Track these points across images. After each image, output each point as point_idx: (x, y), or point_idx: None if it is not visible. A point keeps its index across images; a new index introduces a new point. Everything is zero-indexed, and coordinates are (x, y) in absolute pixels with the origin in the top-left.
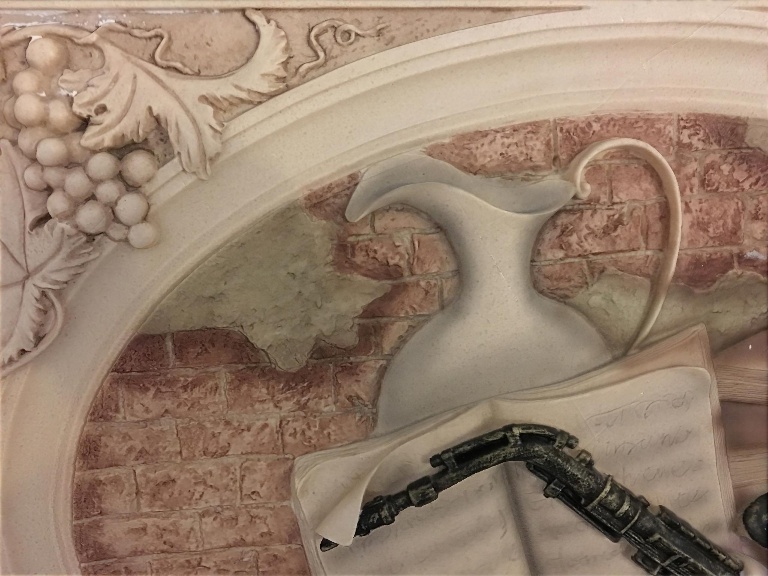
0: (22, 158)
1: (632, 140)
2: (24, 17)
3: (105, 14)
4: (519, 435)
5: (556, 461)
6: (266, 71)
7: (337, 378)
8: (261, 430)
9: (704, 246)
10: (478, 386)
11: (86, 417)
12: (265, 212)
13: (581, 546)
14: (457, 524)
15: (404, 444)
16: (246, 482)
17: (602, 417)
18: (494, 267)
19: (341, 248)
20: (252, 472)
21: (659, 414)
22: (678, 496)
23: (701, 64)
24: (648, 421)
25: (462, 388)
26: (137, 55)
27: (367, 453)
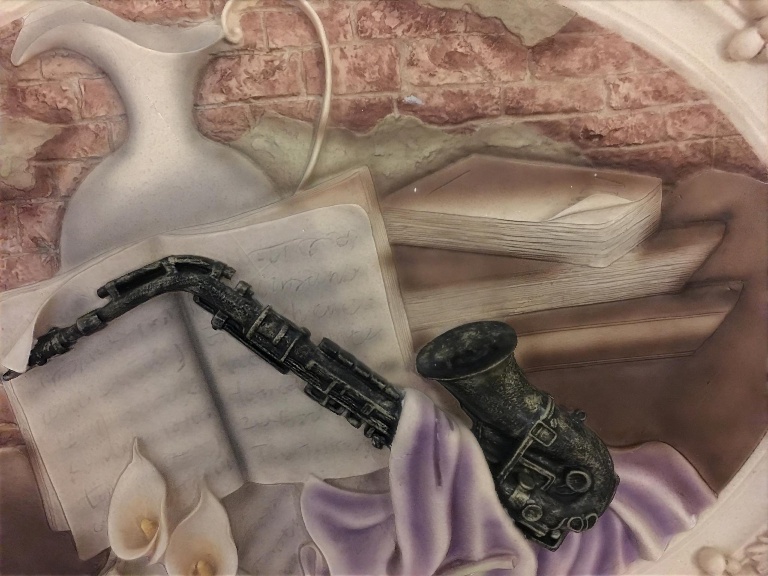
0: None
1: None
2: None
3: None
4: (174, 264)
5: (211, 289)
6: None
7: (19, 219)
8: None
9: (362, 91)
10: (146, 223)
11: None
12: None
13: (257, 380)
14: (134, 356)
15: (75, 277)
16: None
17: (264, 252)
18: (152, 107)
19: (12, 92)
20: None
21: (324, 252)
22: (351, 334)
23: None
24: (314, 259)
25: (131, 225)
26: None
27: (46, 288)
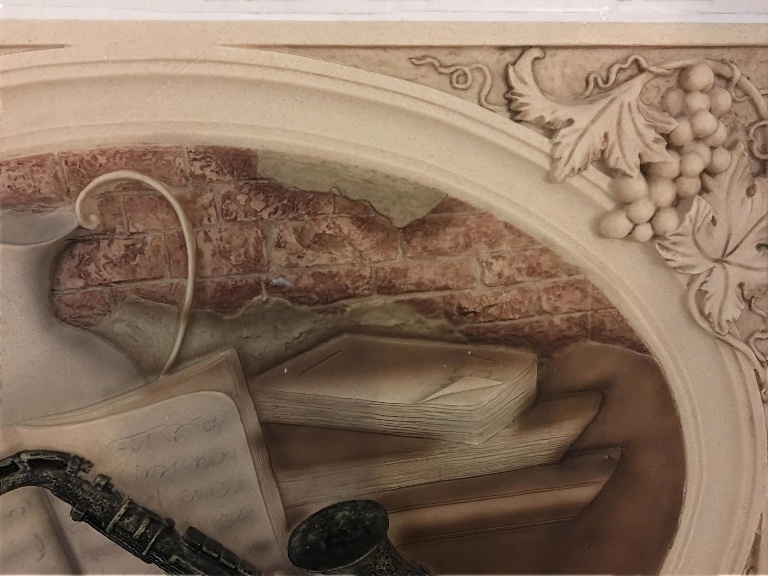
0: None
1: (128, 173)
2: None
3: None
4: (27, 461)
5: (66, 486)
6: None
7: None
8: None
9: (229, 274)
10: (0, 413)
11: None
12: None
13: (122, 567)
14: None
15: None
16: None
17: (125, 442)
18: (4, 297)
19: None
20: None
21: (190, 437)
22: (221, 517)
23: (206, 98)
24: (179, 444)
25: None
26: None
27: None
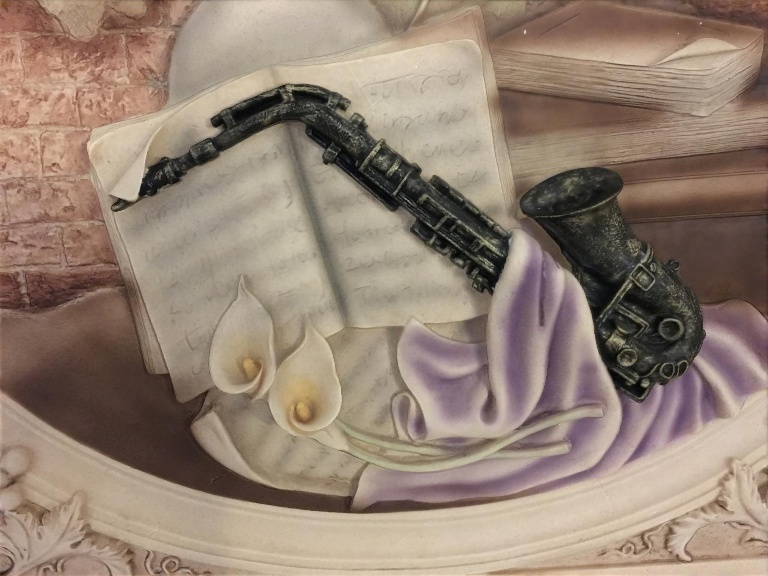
0: None
1: None
2: None
3: None
4: (292, 92)
5: (327, 118)
6: None
7: (128, 48)
8: (58, 100)
9: None
10: (259, 54)
11: None
12: None
13: (364, 219)
14: (243, 191)
15: (187, 105)
16: (46, 153)
17: (377, 86)
18: None
19: None
20: (51, 143)
21: (435, 90)
22: (457, 176)
23: None
24: (425, 97)
25: (244, 55)
26: None
27: (156, 119)
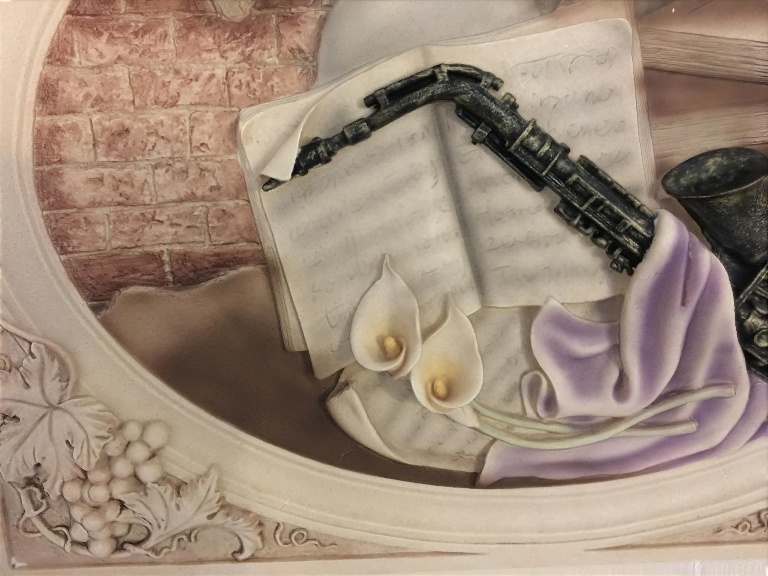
0: None
1: None
2: None
3: None
4: (447, 72)
5: (481, 98)
6: None
7: (279, 28)
8: (208, 81)
9: None
10: (411, 33)
11: (44, 62)
12: None
13: (507, 199)
14: (391, 171)
15: (340, 85)
16: (195, 133)
17: (528, 66)
18: None
19: None
20: (200, 123)
21: (583, 70)
22: (600, 156)
23: None
24: (573, 76)
25: (396, 35)
26: None
27: (307, 99)
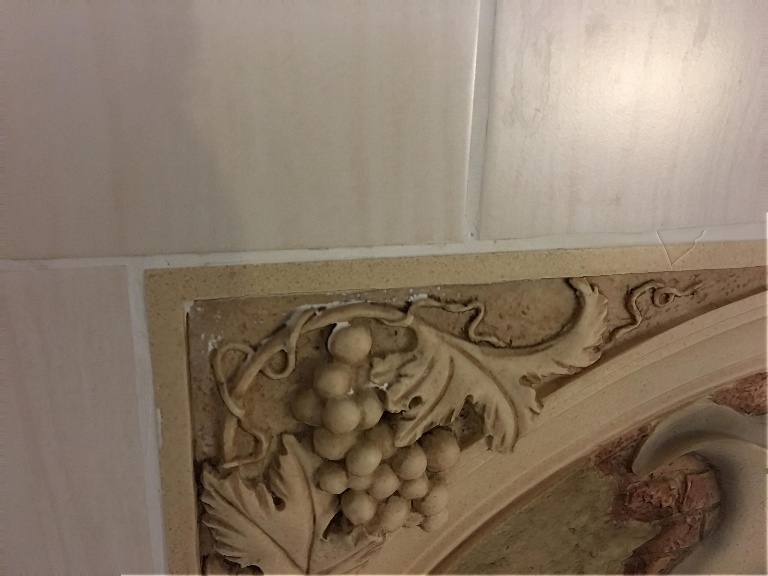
0: (313, 457)
1: None
2: (324, 297)
3: (418, 288)
4: None
5: None
6: (589, 344)
7: None
8: None
9: None
10: None
11: None
12: (553, 472)
13: None
14: None
15: None
16: None
17: None
18: (761, 503)
19: (620, 497)
20: None
21: None
22: None
23: None
24: None
25: None
26: (448, 330)
27: None
